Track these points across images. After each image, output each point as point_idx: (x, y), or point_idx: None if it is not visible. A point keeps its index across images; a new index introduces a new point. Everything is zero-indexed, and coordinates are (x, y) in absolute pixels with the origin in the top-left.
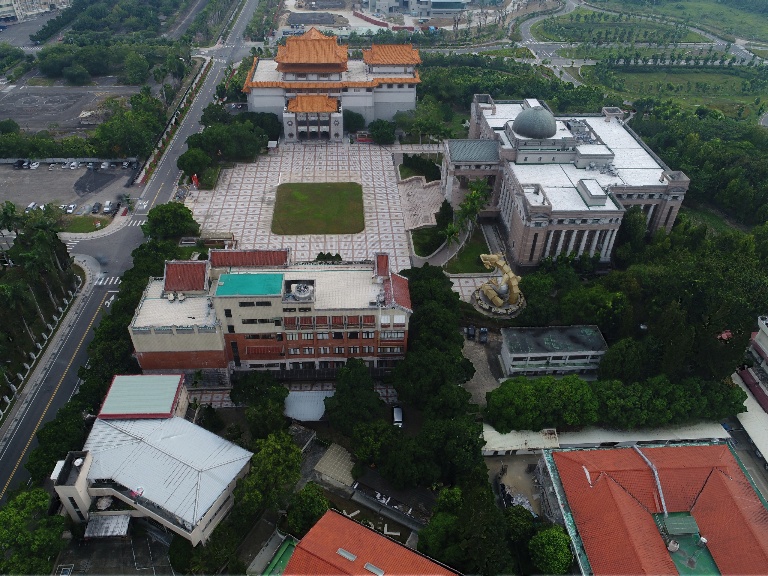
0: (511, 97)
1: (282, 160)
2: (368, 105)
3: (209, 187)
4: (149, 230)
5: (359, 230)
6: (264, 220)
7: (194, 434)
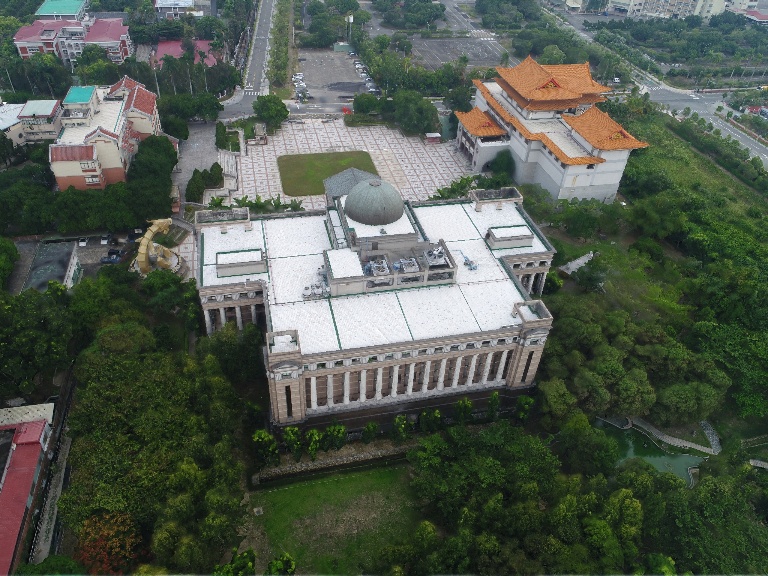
0: (681, 277)
1: (415, 147)
2: (523, 158)
3: (347, 123)
4: (254, 104)
5: (289, 194)
6: (300, 151)
7: (1, 126)
